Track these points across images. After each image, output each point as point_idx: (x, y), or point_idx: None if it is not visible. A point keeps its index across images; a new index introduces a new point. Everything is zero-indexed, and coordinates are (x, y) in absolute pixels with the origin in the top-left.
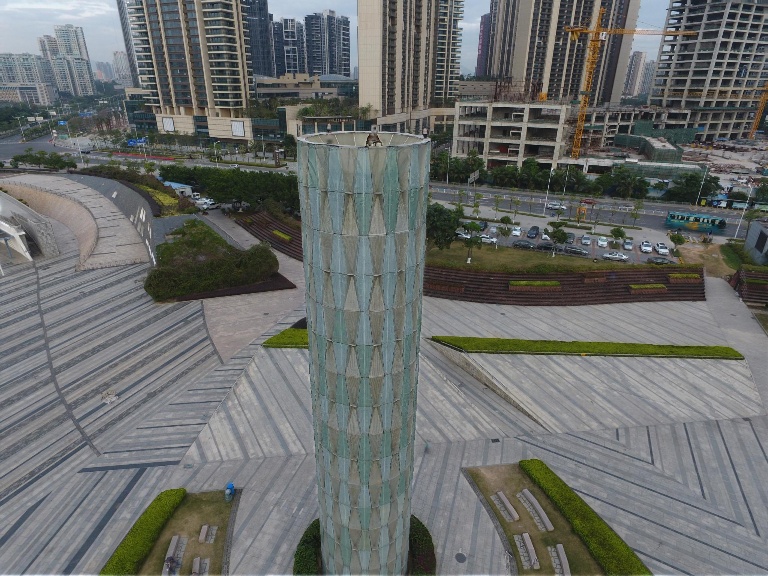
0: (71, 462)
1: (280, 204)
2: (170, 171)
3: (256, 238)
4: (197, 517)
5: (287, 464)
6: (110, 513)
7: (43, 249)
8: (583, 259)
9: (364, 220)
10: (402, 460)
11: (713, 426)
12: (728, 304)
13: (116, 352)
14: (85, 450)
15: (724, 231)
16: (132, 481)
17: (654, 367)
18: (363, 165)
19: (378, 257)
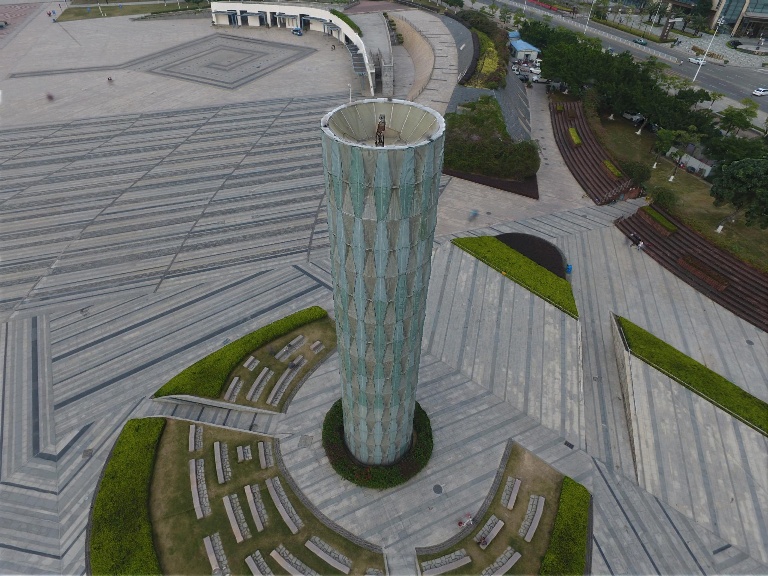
0: (293, 257)
1: (600, 98)
2: (529, 28)
3: (552, 130)
4: (320, 333)
5: None
6: (288, 300)
7: (383, 88)
8: None
9: (341, 198)
10: (380, 386)
11: None
12: None
13: None
14: (304, 254)
15: None
16: (310, 289)
17: None
18: (338, 154)
19: (351, 231)
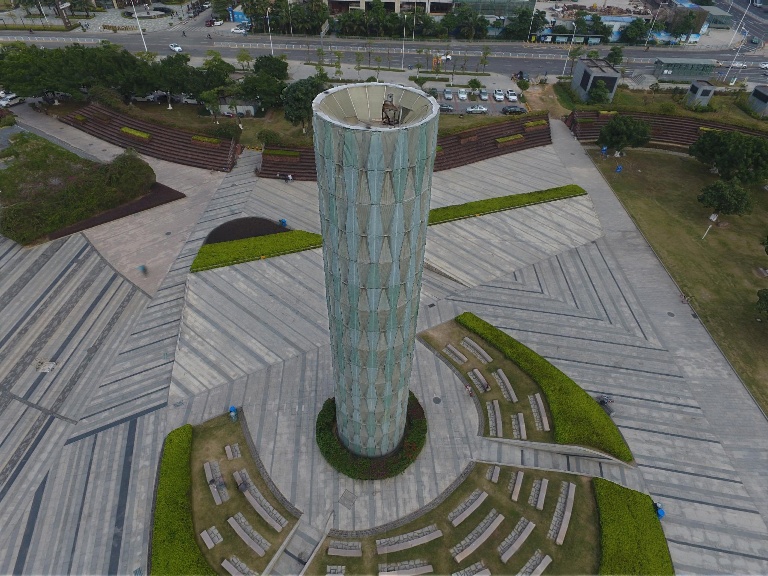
0: (49, 439)
1: (115, 91)
2: None
3: (101, 140)
4: (215, 442)
5: (271, 374)
6: (127, 467)
7: None
8: (450, 116)
9: (399, 189)
10: None
11: (574, 253)
12: (568, 144)
13: (15, 316)
14: (56, 423)
15: (553, 69)
16: (129, 434)
17: (530, 214)
18: (401, 144)
19: (408, 216)
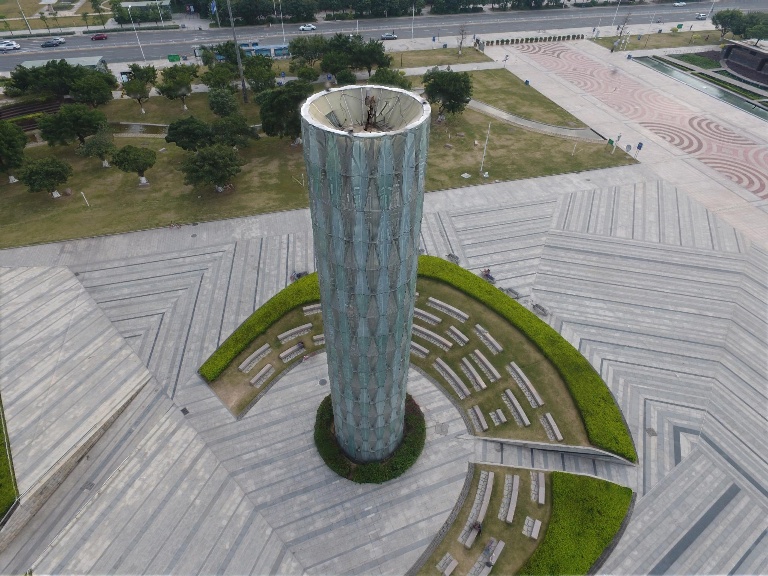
0: None
1: None
2: None
3: None
4: None
5: None
6: None
7: None
8: None
9: None
10: None
11: (95, 289)
12: None
13: None
14: None
15: None
16: None
17: (8, 322)
18: None
19: None
